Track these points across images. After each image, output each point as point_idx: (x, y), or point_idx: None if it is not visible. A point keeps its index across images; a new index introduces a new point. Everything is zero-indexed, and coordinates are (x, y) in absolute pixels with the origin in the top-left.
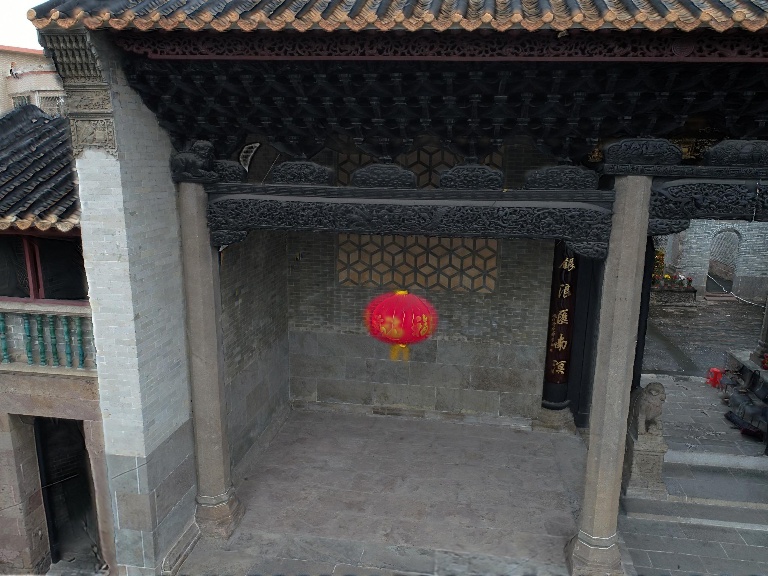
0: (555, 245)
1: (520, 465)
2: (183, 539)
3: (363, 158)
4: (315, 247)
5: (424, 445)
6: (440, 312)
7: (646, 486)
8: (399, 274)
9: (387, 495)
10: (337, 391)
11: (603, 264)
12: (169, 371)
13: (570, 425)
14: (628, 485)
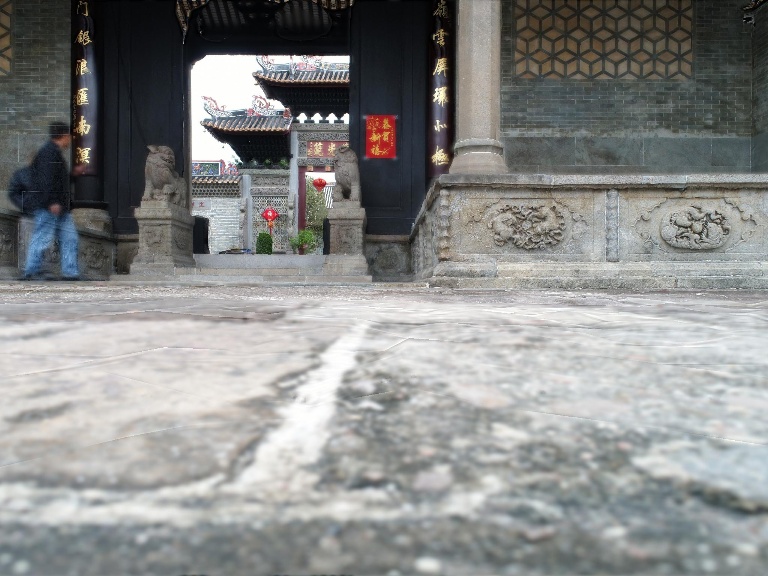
0: (71, 20)
1: None
2: None
3: None
4: None
5: None
6: None
7: (152, 260)
8: None
9: None
10: None
11: (131, 47)
12: None
13: (98, 222)
14: (132, 261)
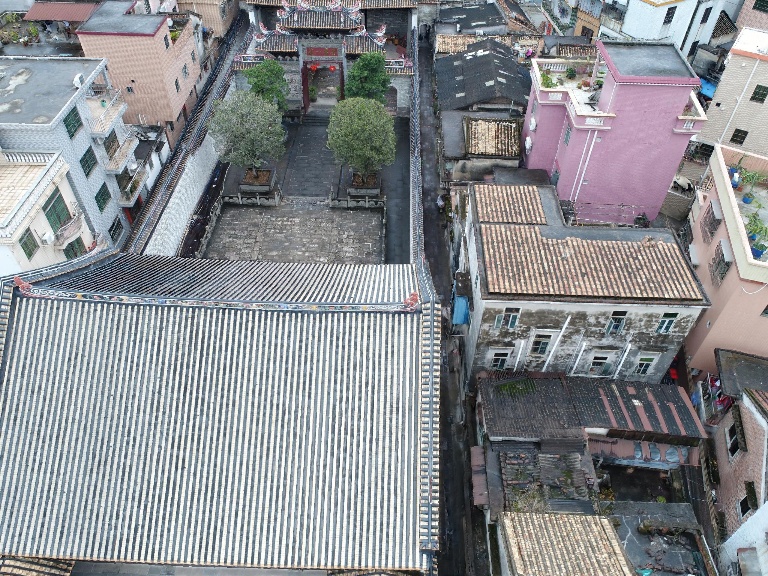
0: None
1: None
2: None
3: None
4: None
5: None
6: None
7: None
8: None
9: None
10: None
11: None
12: None
13: None
14: None
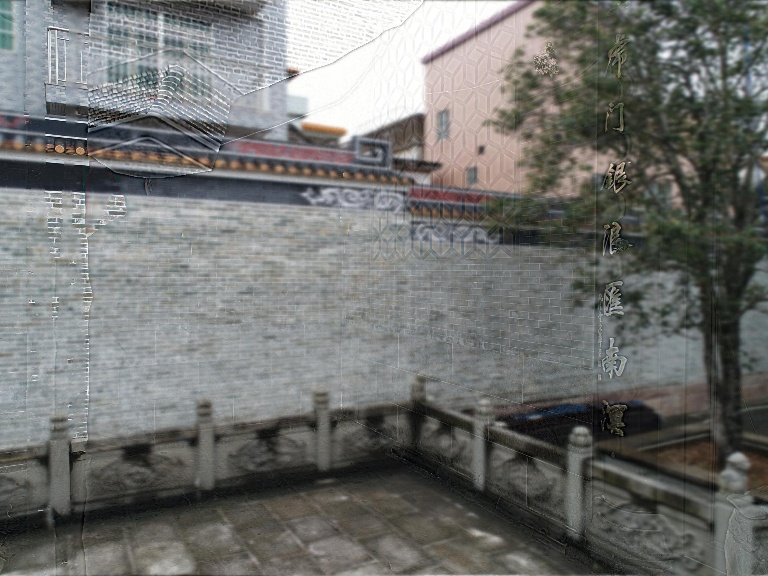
0: (598, 145)
1: (413, 575)
2: (5, 455)
3: (390, 86)
4: (359, 215)
5: (361, 497)
6: (454, 296)
7: None
8: (417, 239)
9: (192, 512)
10: (371, 411)
11: (719, 172)
12: (6, 268)
13: (636, 570)
14: None
